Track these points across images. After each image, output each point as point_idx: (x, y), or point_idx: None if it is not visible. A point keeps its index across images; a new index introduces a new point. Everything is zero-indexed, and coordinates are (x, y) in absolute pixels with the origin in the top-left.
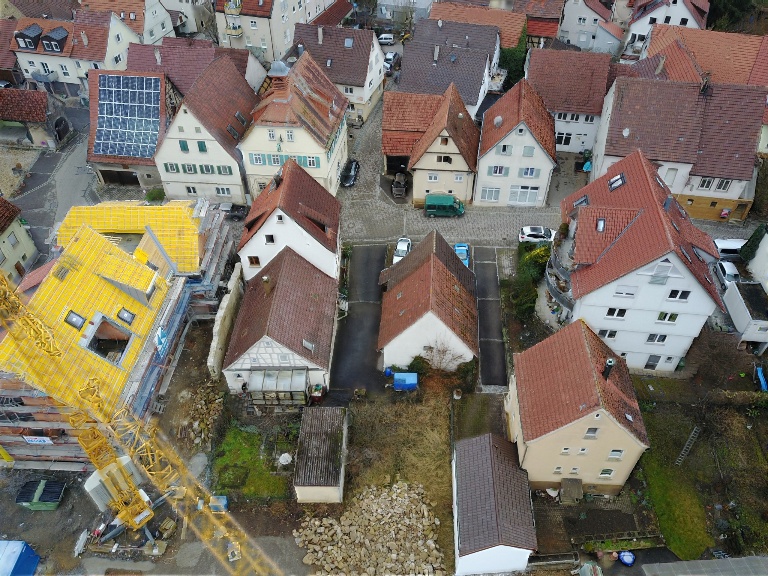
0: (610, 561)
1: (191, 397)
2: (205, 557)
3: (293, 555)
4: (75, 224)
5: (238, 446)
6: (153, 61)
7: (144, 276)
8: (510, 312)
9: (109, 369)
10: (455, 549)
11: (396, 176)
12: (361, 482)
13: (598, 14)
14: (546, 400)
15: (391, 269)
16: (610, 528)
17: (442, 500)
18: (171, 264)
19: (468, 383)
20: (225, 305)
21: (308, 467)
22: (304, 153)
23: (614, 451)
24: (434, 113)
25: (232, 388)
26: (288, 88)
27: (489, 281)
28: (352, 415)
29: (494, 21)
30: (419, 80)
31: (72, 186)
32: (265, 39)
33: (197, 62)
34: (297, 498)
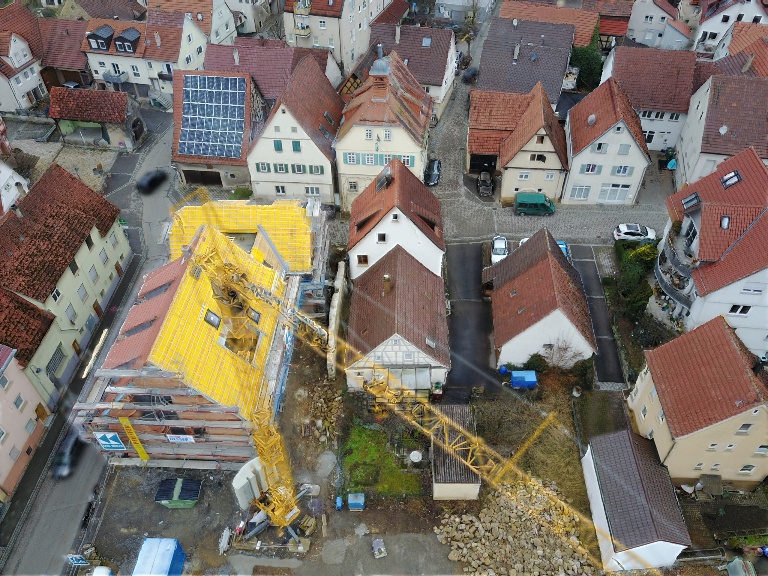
0: (755, 557)
1: (308, 395)
2: (350, 554)
3: (437, 552)
4: (187, 224)
5: (364, 444)
6: (231, 61)
7: (266, 275)
8: (617, 310)
9: (245, 368)
10: (599, 545)
11: (481, 175)
12: (493, 479)
13: (666, 12)
14: (693, 396)
15: (495, 267)
16: (751, 524)
17: (577, 497)
18: (283, 263)
19: (588, 380)
20: (336, 304)
21: (447, 464)
22: (399, 152)
23: (761, 447)
24: (522, 112)
25: (351, 386)
26: (387, 87)
27: (591, 279)
28: (481, 413)
29: (566, 20)
30: (498, 79)
31: (154, 186)
32: (333, 39)
33: (276, 62)
34: (432, 495)
